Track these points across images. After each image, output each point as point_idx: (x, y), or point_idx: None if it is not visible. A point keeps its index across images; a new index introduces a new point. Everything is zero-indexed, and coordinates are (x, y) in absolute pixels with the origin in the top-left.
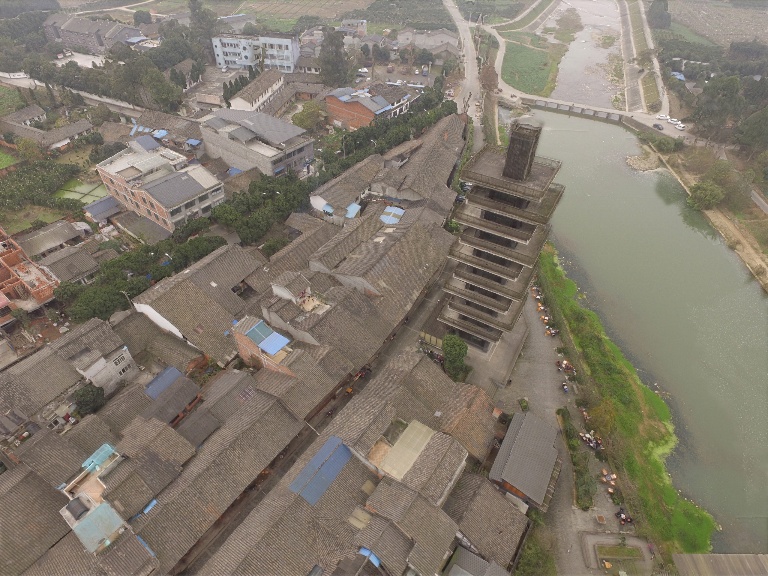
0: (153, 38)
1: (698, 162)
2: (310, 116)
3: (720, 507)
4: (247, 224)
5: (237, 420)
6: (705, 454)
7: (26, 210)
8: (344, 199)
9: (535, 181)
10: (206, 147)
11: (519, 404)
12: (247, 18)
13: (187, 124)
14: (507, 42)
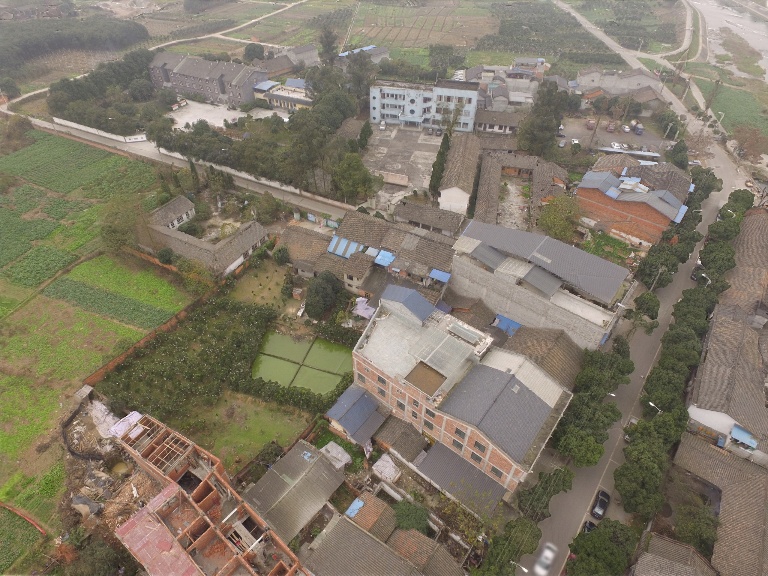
0: (271, 77)
1: None
2: (569, 220)
3: None
4: (642, 483)
5: None
6: None
7: (227, 402)
8: (760, 416)
9: None
10: (453, 280)
11: None
12: (381, 52)
13: (419, 242)
14: (694, 78)
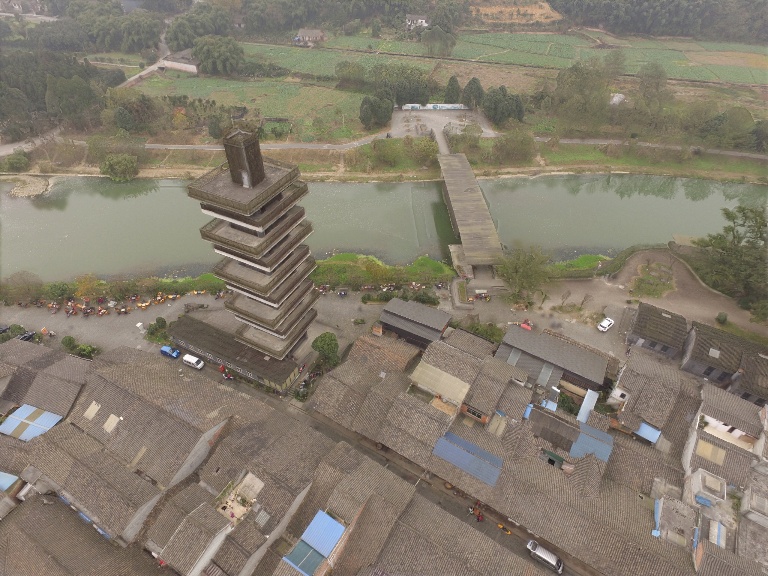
0: None
1: (71, 153)
2: None
3: (415, 251)
4: None
5: (424, 575)
6: (380, 247)
7: None
8: None
9: (266, 172)
10: None
11: (359, 325)
12: None
13: None
14: None
